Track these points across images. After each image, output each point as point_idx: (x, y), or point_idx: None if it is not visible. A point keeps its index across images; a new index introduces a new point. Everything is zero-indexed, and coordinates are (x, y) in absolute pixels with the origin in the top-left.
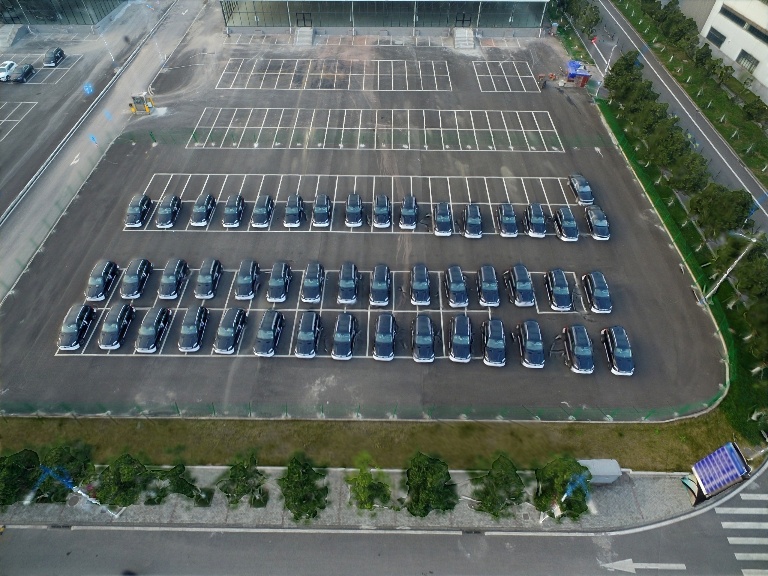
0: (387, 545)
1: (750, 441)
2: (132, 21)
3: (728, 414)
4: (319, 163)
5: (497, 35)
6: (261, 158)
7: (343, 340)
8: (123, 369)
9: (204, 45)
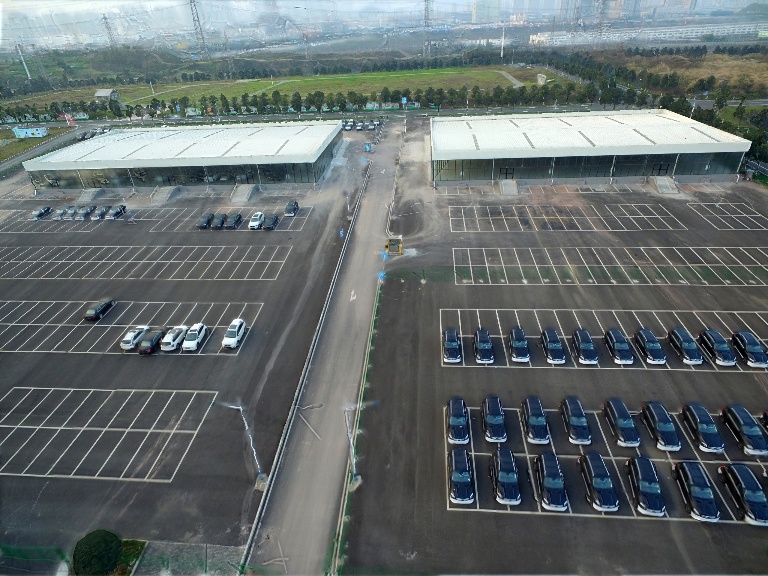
0: None
1: None
2: (342, 179)
3: None
4: (603, 298)
5: (693, 181)
6: (539, 294)
7: None
8: (539, 531)
9: (418, 196)
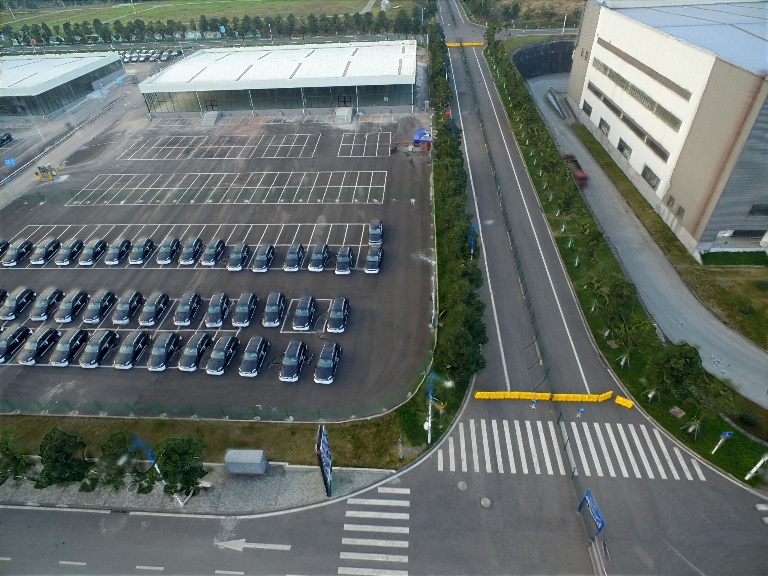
0: (40, 519)
1: (412, 442)
2: (81, 112)
3: (402, 418)
4: (166, 215)
5: (376, 112)
6: (120, 212)
7: (92, 351)
8: None
9: (127, 128)
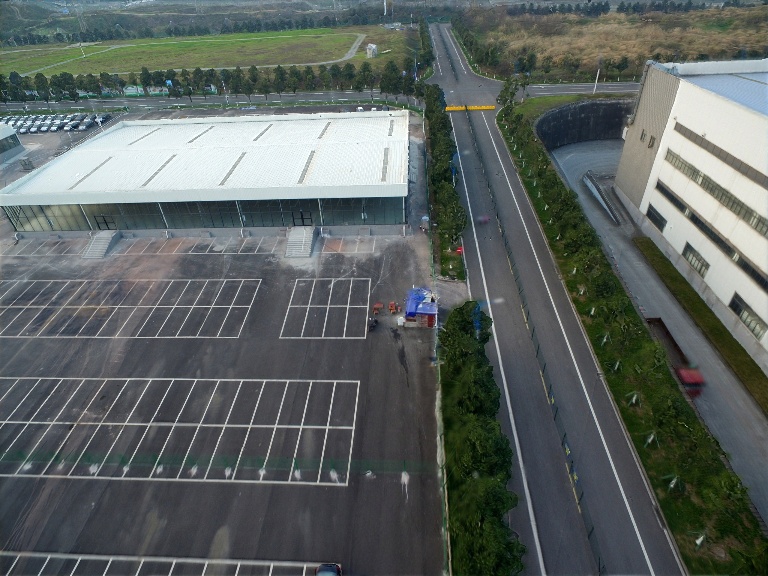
0: None
1: None
2: None
3: None
4: None
5: (350, 233)
6: None
7: None
8: None
9: None
